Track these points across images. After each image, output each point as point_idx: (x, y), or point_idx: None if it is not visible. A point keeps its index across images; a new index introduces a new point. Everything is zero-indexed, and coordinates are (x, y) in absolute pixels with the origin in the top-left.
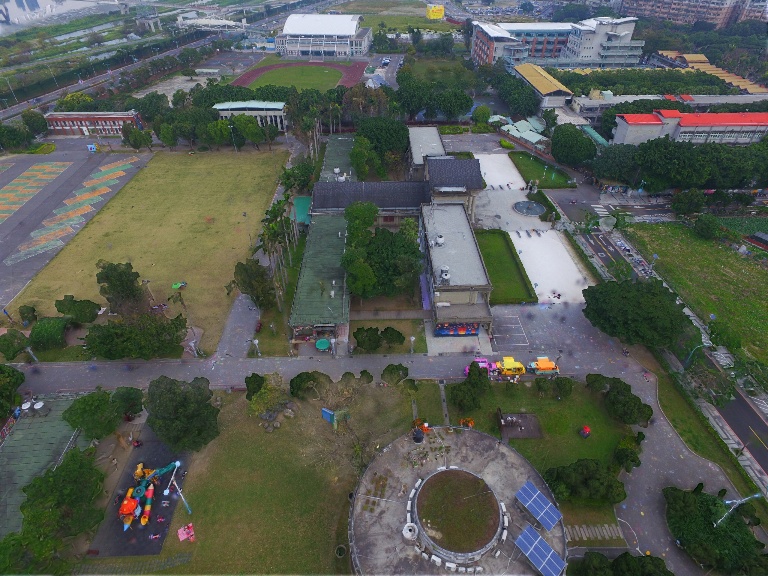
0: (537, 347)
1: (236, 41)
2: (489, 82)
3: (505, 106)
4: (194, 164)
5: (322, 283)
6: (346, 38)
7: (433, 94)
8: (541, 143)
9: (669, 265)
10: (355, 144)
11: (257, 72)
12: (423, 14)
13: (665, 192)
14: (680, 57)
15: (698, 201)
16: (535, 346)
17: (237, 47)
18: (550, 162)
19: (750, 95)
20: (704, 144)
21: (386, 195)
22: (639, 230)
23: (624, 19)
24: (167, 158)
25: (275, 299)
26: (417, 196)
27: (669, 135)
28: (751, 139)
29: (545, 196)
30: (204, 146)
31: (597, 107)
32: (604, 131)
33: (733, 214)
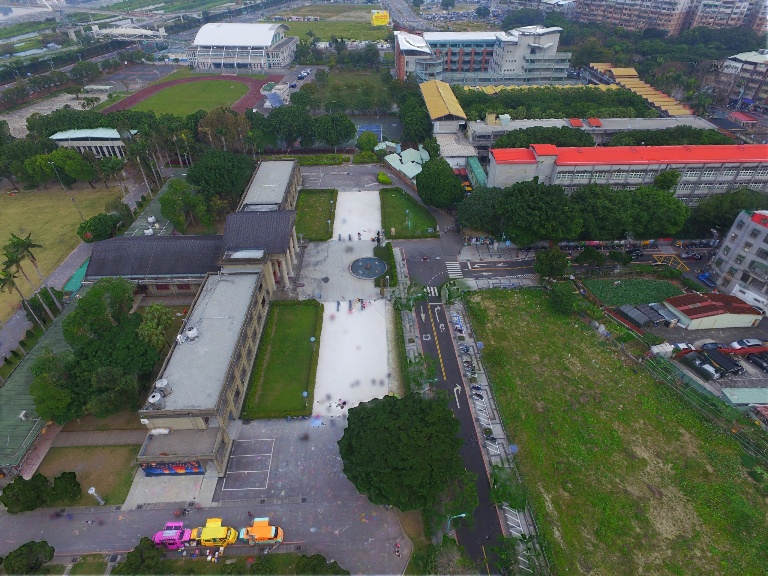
0: (275, 493)
1: (151, 52)
2: None
3: None
4: (6, 207)
5: (26, 394)
6: (261, 49)
7: (309, 119)
8: None
9: (502, 354)
10: (169, 189)
11: (156, 88)
12: None
13: (538, 244)
14: (609, 71)
15: (556, 264)
16: (273, 491)
17: (148, 59)
18: None
19: (669, 118)
20: (588, 185)
21: (180, 258)
22: (487, 299)
23: (547, 29)
24: None
25: None
26: (217, 259)
27: (545, 175)
28: (643, 179)
29: (390, 252)
30: None
31: (489, 134)
32: None
33: (609, 275)
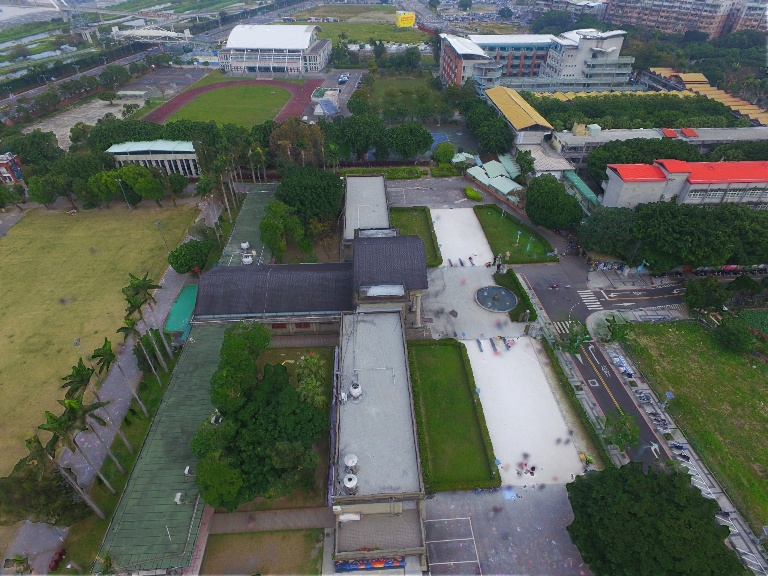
0: None
1: (177, 55)
2: (458, 105)
3: (474, 138)
4: (70, 230)
5: (171, 469)
6: (298, 52)
7: (384, 129)
8: (514, 194)
9: (688, 403)
10: (267, 212)
11: (192, 93)
12: (394, 21)
13: (672, 269)
14: (675, 76)
15: (721, 297)
16: None
17: (176, 62)
18: (525, 220)
19: (763, 127)
20: (719, 204)
21: (298, 292)
22: (642, 335)
23: (611, 33)
24: (38, 220)
25: (87, 508)
26: (341, 293)
27: (675, 194)
28: None
29: (517, 280)
30: (91, 202)
31: (582, 146)
32: (591, 176)
33: (763, 305)
